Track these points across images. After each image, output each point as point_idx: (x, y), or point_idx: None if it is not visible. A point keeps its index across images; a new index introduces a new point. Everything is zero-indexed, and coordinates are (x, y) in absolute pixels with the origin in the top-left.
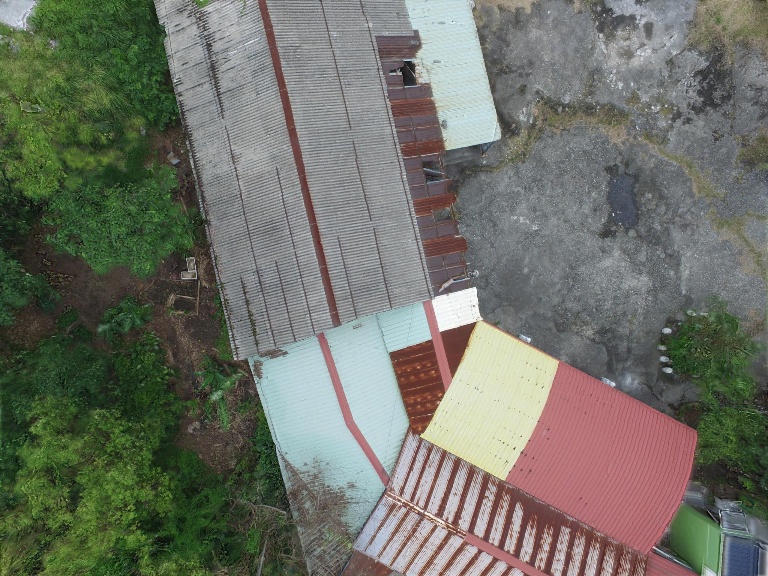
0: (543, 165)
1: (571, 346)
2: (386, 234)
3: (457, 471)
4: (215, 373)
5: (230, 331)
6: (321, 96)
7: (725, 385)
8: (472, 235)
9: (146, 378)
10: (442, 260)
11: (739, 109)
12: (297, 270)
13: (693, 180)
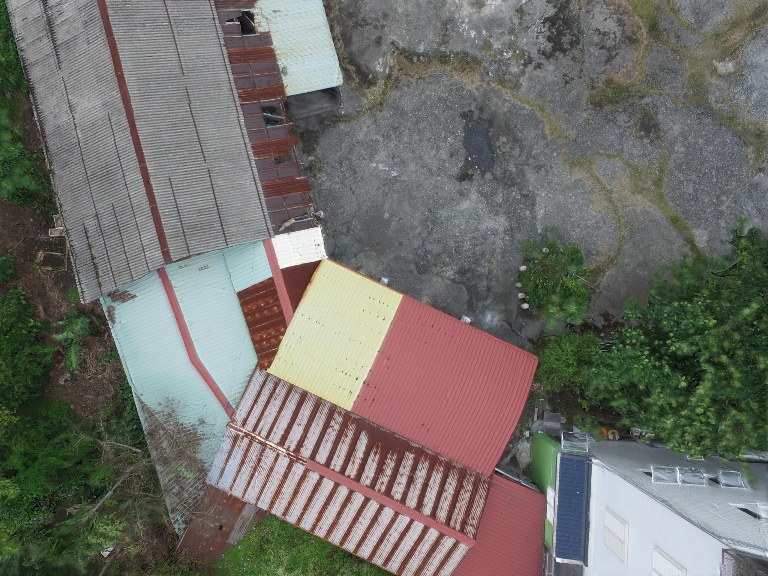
0: (400, 113)
1: (432, 287)
2: (222, 175)
3: (303, 403)
4: (78, 323)
5: (76, 276)
6: (152, 44)
7: (582, 319)
8: (333, 183)
9: (11, 330)
10: (283, 201)
11: (588, 52)
12: (131, 211)
13: (545, 122)
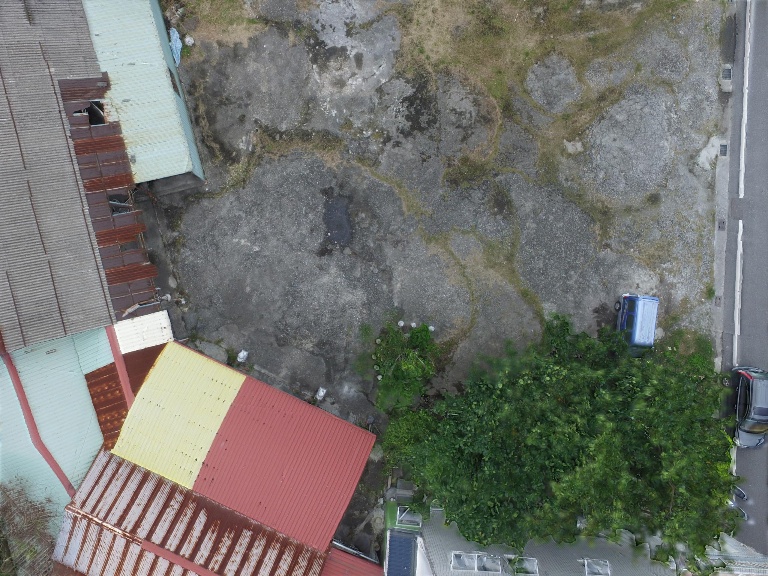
0: (262, 190)
1: (291, 359)
2: (63, 266)
3: (145, 483)
4: None
5: None
6: None
7: (436, 389)
8: (196, 258)
9: None
10: (128, 287)
11: (445, 131)
12: None
13: (402, 199)
